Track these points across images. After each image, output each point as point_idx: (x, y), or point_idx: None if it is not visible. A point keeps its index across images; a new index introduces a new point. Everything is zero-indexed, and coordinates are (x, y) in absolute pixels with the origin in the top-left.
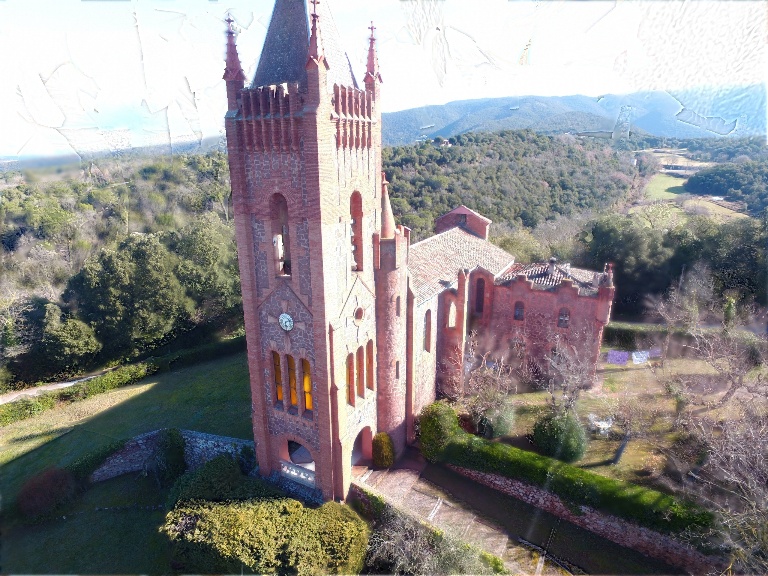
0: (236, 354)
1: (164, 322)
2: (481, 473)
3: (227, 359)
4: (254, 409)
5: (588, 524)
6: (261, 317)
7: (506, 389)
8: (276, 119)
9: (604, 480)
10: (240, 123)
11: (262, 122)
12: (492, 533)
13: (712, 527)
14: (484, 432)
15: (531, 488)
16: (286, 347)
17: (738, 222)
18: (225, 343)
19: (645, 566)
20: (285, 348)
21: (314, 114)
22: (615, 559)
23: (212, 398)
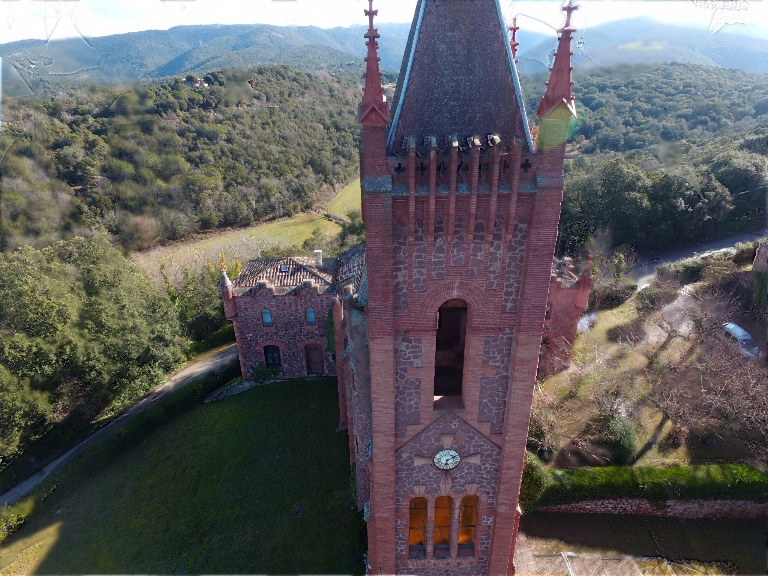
0: (140, 444)
1: (4, 442)
2: (572, 504)
3: (132, 457)
4: (381, 572)
5: (669, 512)
6: (399, 462)
7: (555, 407)
8: (479, 194)
9: (681, 472)
10: (397, 199)
11: (452, 199)
12: (623, 566)
13: (767, 482)
14: (545, 457)
15: (621, 501)
16: (443, 488)
17: (584, 179)
18: (120, 436)
19: (722, 530)
20: (441, 490)
21: (558, 189)
22: (704, 535)
23: (178, 536)
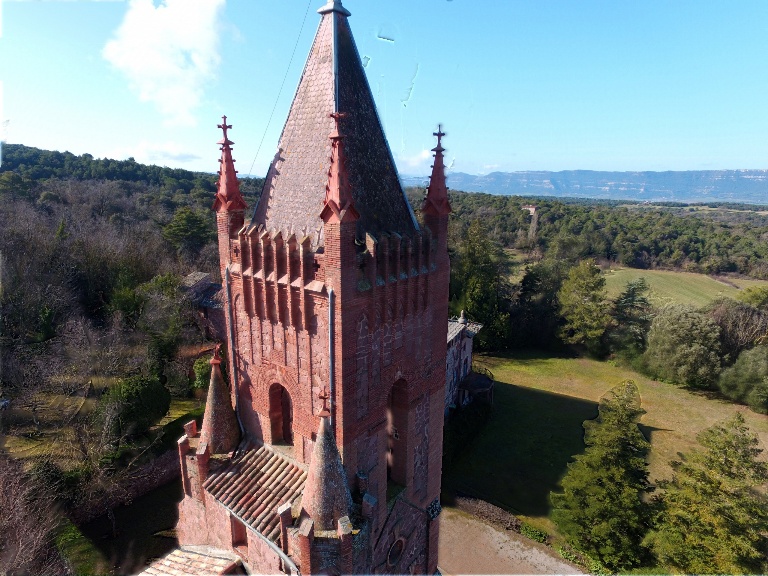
0: None
1: None
2: None
3: None
4: None
5: None
6: None
7: None
8: None
9: (90, 567)
10: None
11: None
12: None
13: None
14: None
15: None
16: None
17: None
18: None
19: None
20: None
21: None
22: None
23: None
